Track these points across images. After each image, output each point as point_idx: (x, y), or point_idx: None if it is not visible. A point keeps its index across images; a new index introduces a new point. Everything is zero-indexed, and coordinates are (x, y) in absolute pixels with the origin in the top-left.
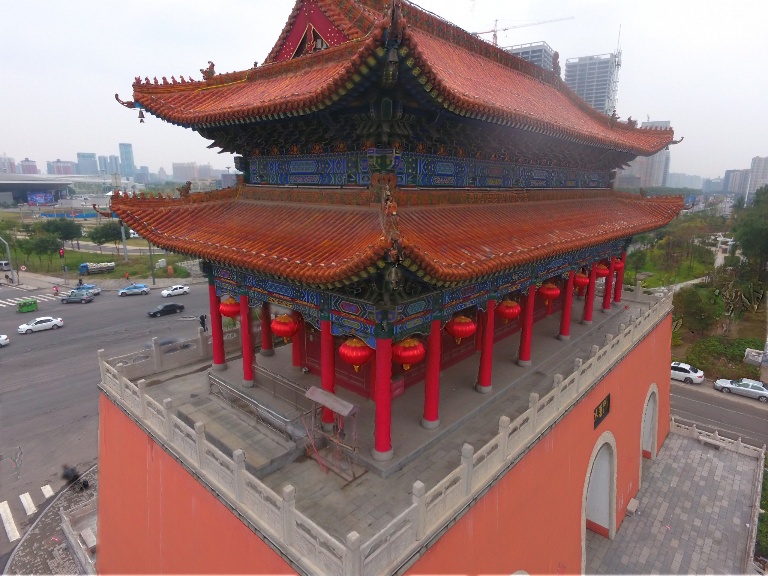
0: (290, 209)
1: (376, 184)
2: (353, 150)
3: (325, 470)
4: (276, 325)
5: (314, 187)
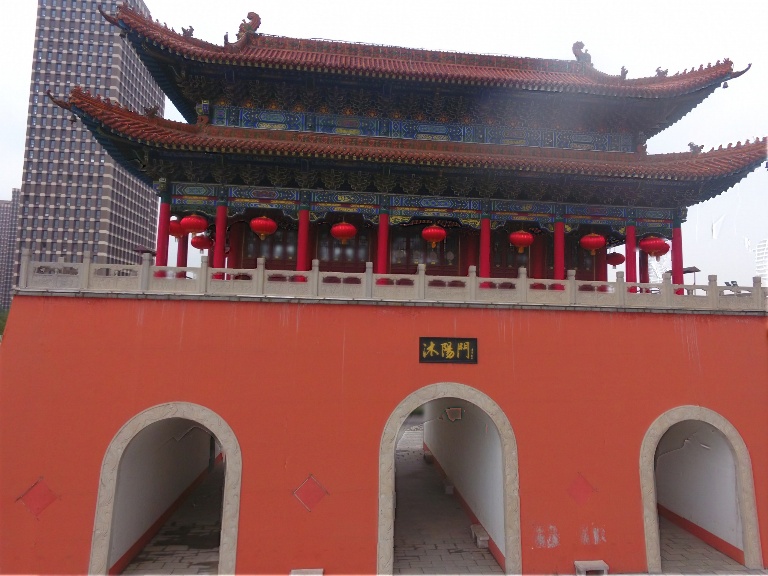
0: None
1: None
2: None
3: None
4: None
5: None
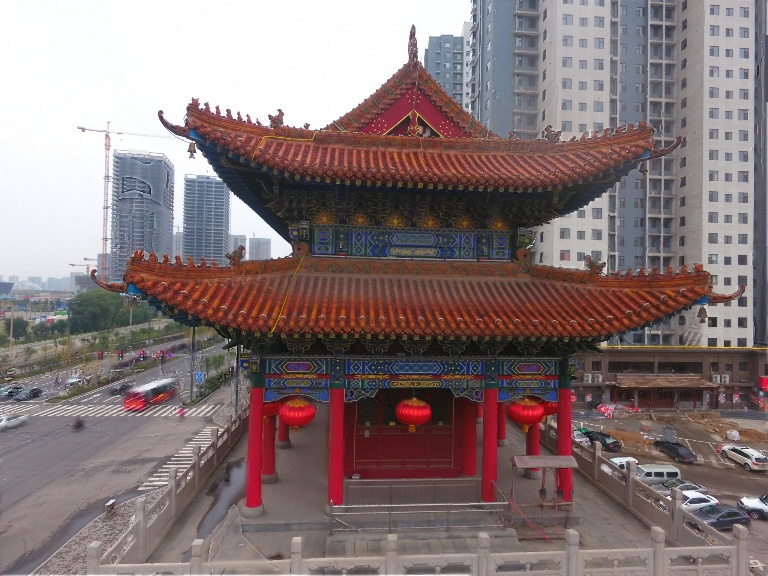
0: (411, 281)
1: (523, 258)
2: (486, 228)
3: (549, 540)
4: (416, 411)
5: (438, 260)
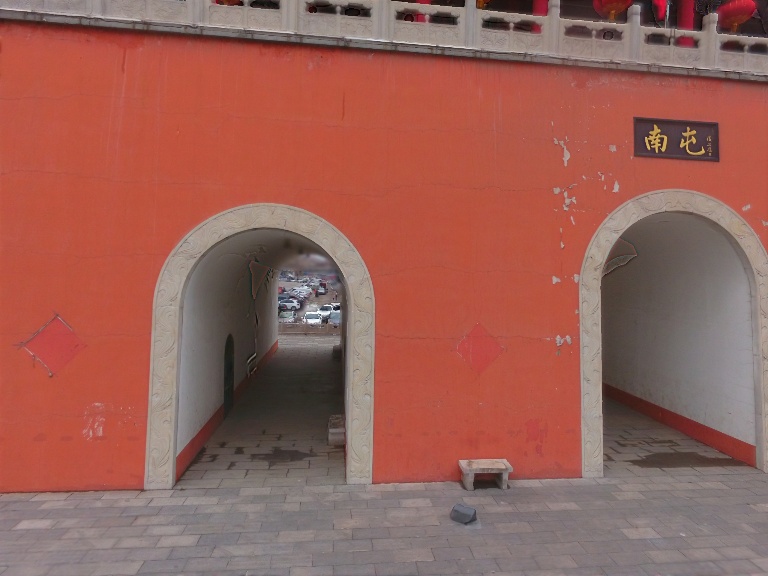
0: None
1: None
2: None
3: None
4: None
5: None
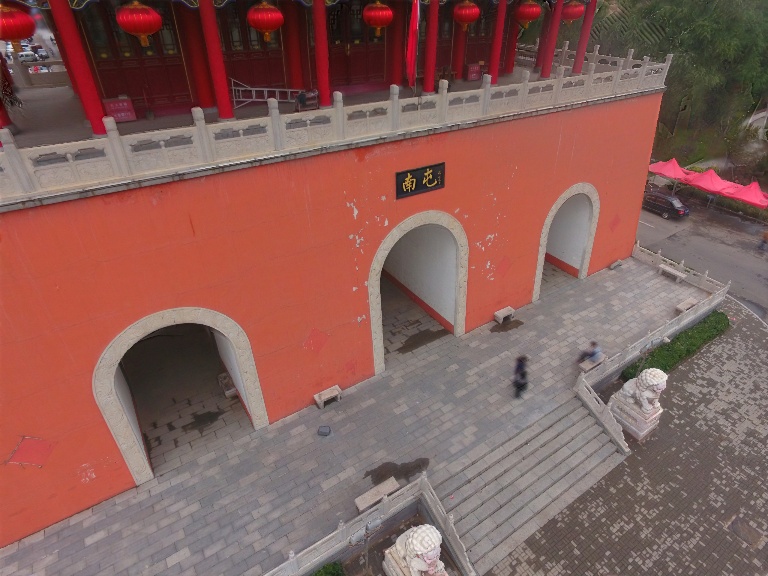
0: None
1: None
2: None
3: None
4: None
5: None
